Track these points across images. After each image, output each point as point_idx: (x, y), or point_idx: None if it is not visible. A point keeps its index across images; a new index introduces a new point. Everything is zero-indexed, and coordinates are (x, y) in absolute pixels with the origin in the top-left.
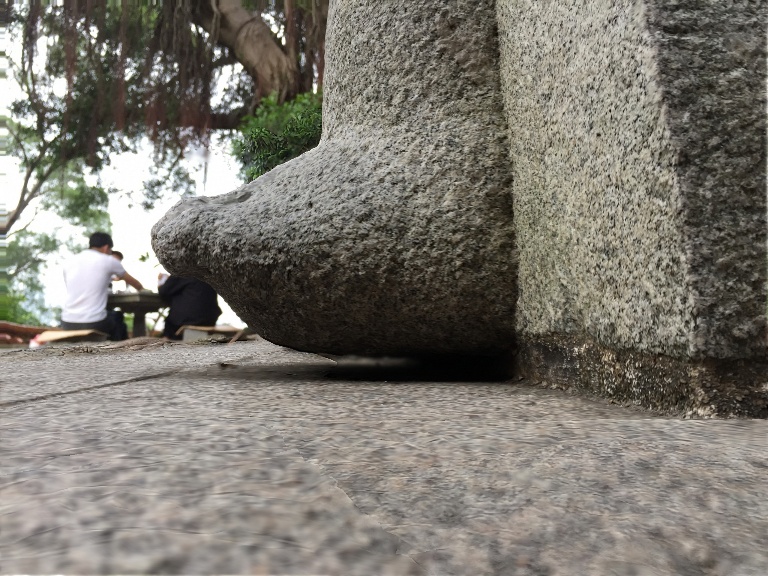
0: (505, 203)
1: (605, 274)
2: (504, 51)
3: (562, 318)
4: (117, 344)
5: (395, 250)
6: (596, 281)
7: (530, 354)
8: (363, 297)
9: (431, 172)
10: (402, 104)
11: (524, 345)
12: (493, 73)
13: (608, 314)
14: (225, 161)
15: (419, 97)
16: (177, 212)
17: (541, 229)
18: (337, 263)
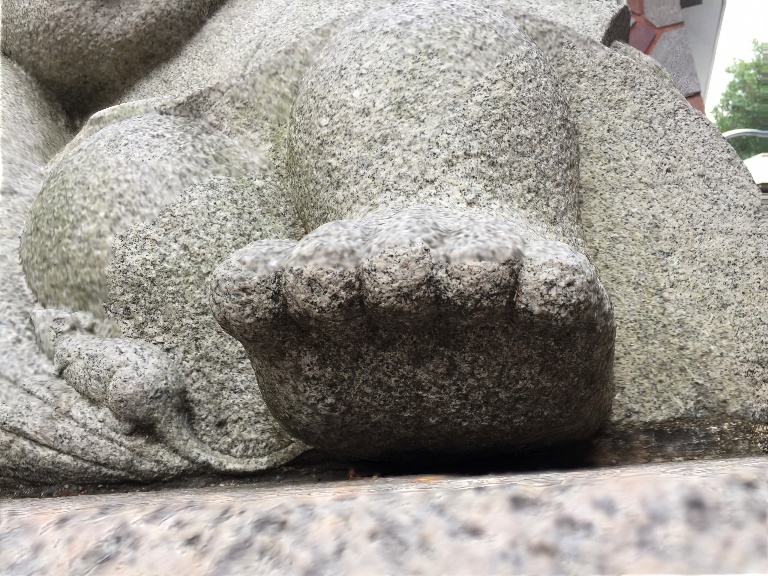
0: None
1: (762, 376)
2: (592, 203)
3: (694, 407)
4: None
5: None
6: (749, 380)
7: (635, 439)
8: None
9: None
10: None
11: (621, 433)
12: None
13: (767, 400)
14: None
15: None
16: None
17: (660, 342)
18: None
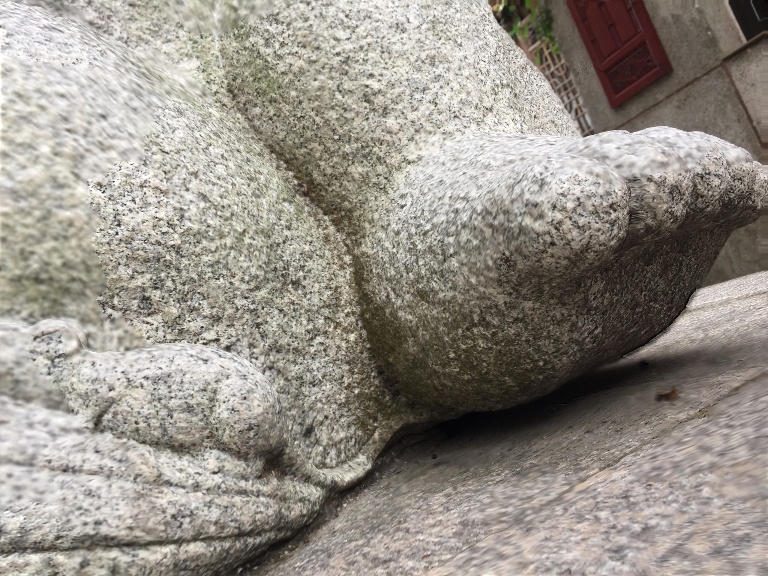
0: None
1: None
2: None
3: None
4: None
5: None
6: None
7: None
8: None
9: None
10: None
11: None
12: None
13: None
14: None
15: None
16: None
17: None
18: None
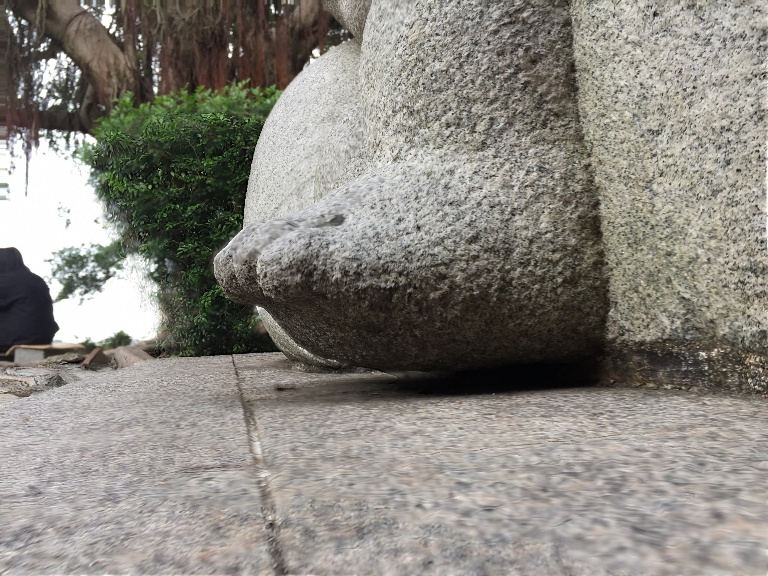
0: (593, 224)
1: (753, 289)
2: (586, 87)
3: (681, 327)
4: None
5: (504, 270)
6: (738, 295)
7: (628, 359)
8: (475, 315)
9: (525, 196)
10: (487, 131)
11: (617, 351)
12: (572, 106)
13: (758, 323)
14: (75, 166)
15: (505, 125)
16: (269, 237)
17: (648, 248)
18: (453, 284)
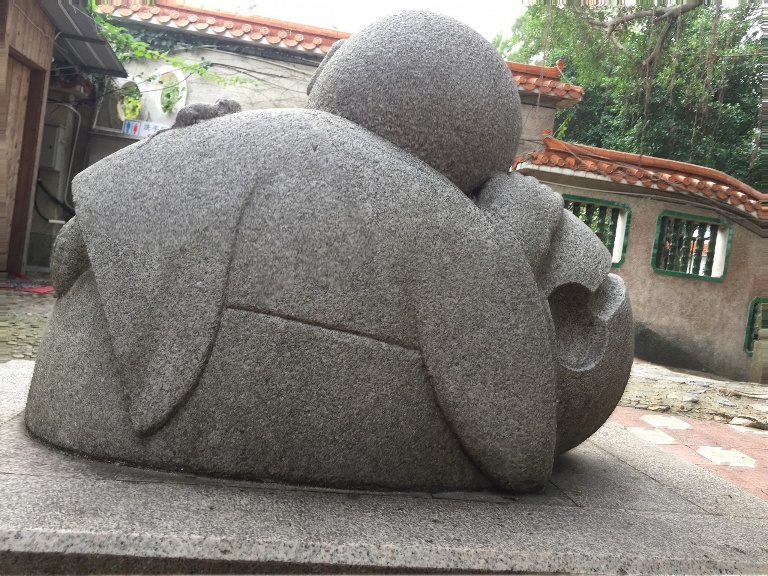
0: None
1: None
2: None
3: None
4: (767, 395)
5: None
6: None
7: None
8: None
9: None
10: None
11: None
12: None
13: None
14: None
15: None
16: None
17: None
18: None
